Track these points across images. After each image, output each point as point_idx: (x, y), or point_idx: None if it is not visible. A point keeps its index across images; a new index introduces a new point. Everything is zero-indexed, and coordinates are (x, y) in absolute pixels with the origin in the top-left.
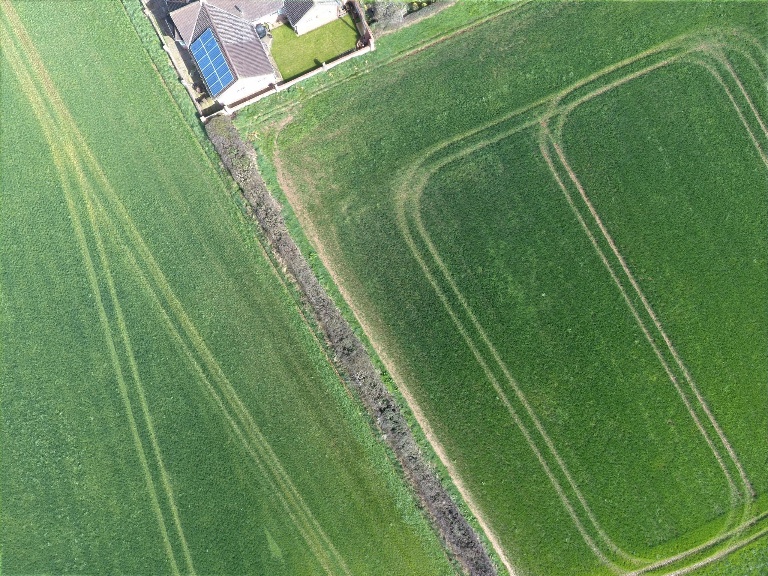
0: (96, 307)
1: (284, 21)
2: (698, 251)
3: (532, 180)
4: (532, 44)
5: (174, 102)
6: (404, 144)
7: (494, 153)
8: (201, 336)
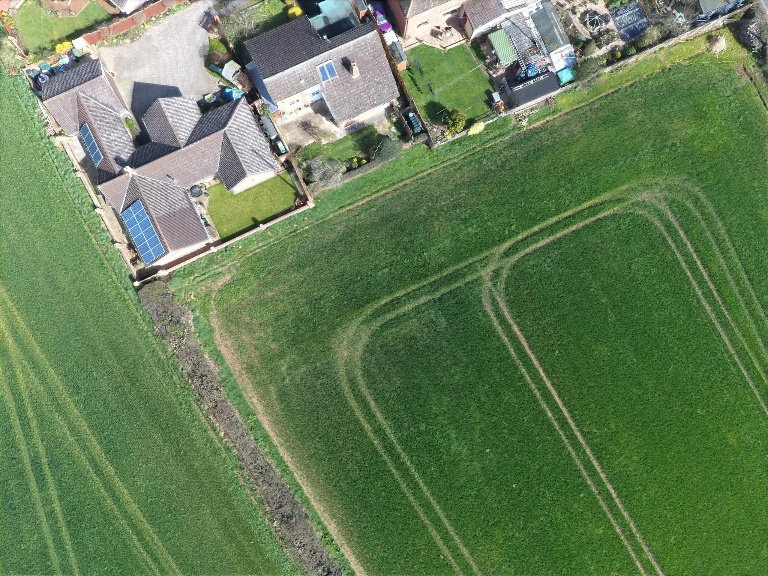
0: (26, 477)
1: None
2: (642, 402)
3: (475, 335)
4: (474, 197)
5: (107, 264)
6: (344, 302)
7: (436, 308)
8: (136, 504)
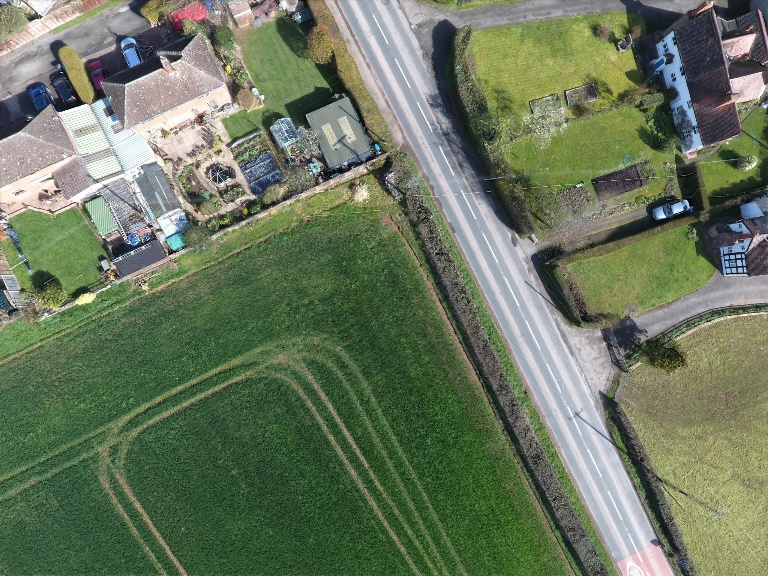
0: None
1: None
2: None
3: (90, 516)
4: (88, 370)
5: None
6: None
7: (47, 490)
8: None
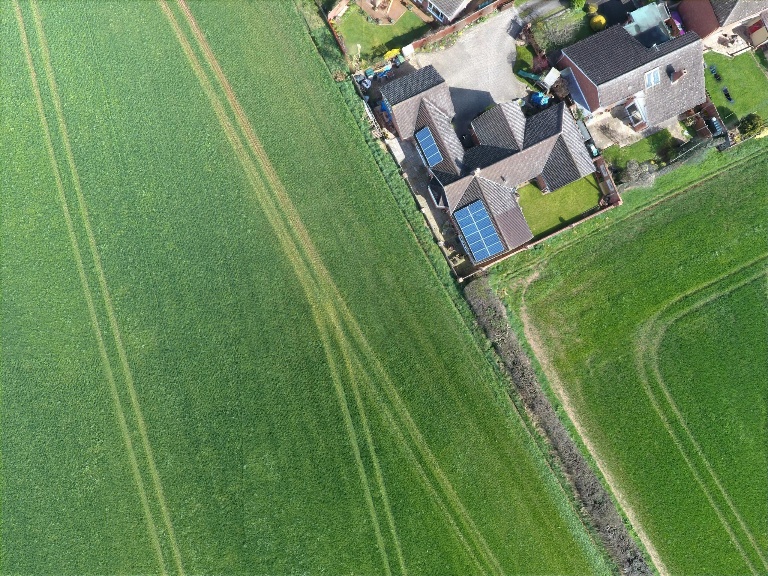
0: (356, 464)
1: (530, 180)
2: None
3: (761, 330)
4: (759, 198)
5: (428, 261)
6: (644, 298)
7: (726, 305)
8: (455, 490)
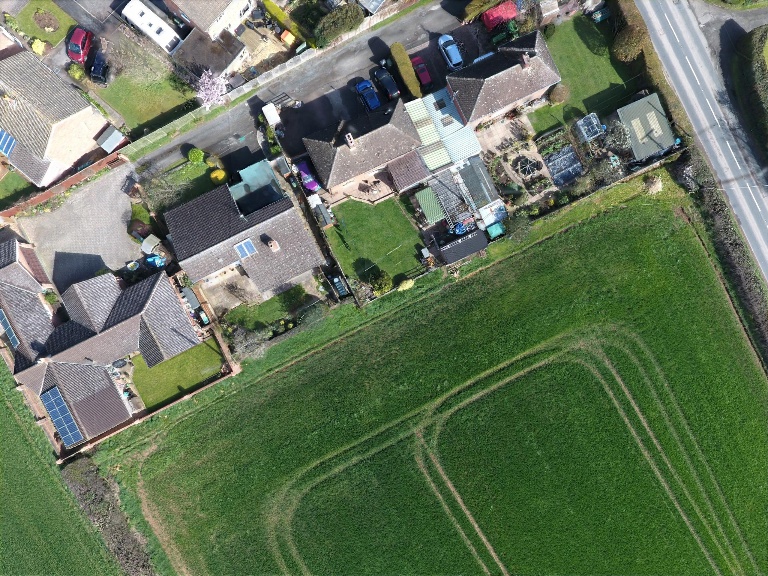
0: None
1: None
2: (580, 554)
3: (408, 494)
4: (405, 354)
5: (31, 439)
6: (273, 468)
7: (368, 468)
8: None
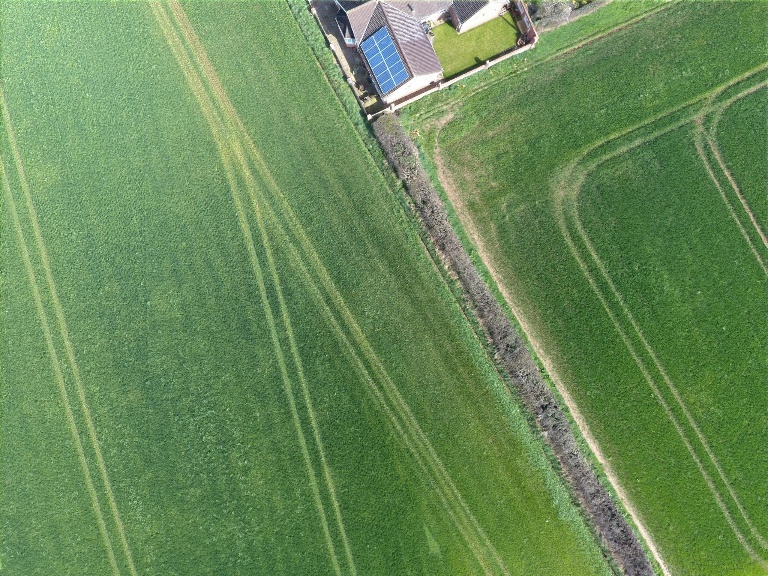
0: (262, 304)
1: (445, 19)
2: None
3: (688, 178)
4: (688, 42)
5: (338, 100)
6: (563, 142)
7: (651, 151)
8: (364, 333)
